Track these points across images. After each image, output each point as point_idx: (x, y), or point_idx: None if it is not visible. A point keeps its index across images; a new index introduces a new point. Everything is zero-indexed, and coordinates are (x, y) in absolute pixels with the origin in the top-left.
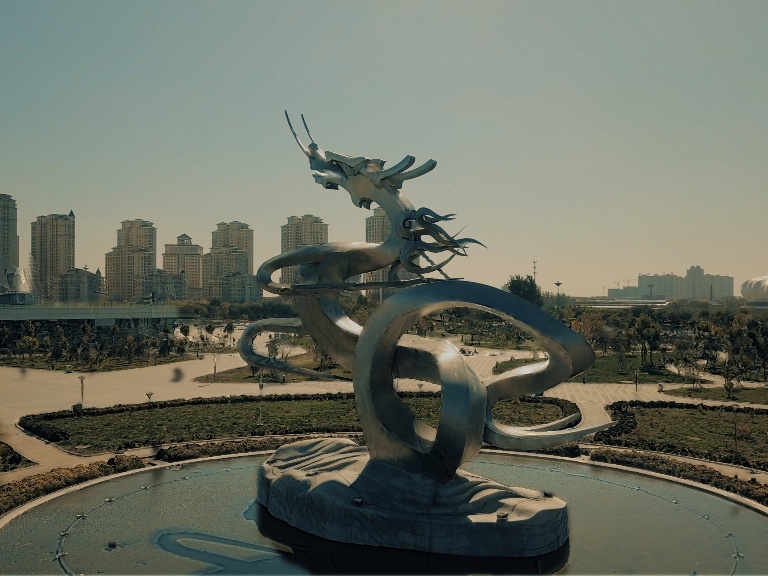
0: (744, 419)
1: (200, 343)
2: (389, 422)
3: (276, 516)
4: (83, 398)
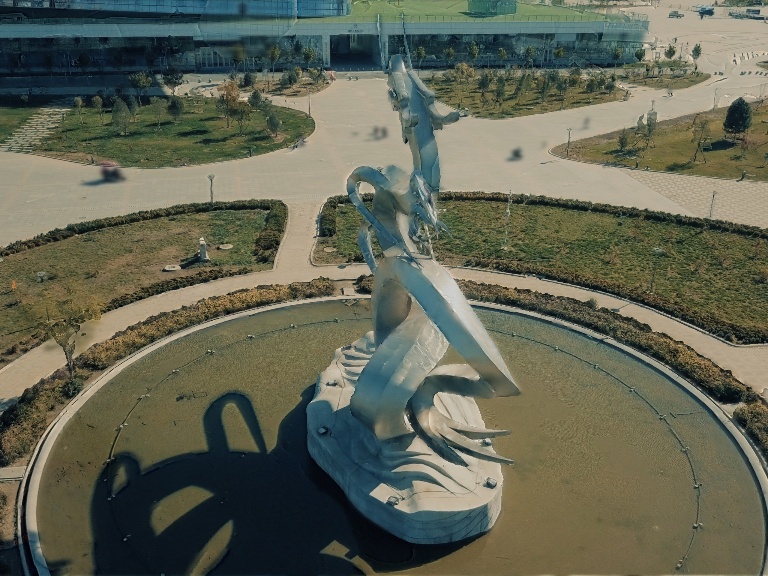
0: None
1: (656, 69)
2: None
3: None
4: None
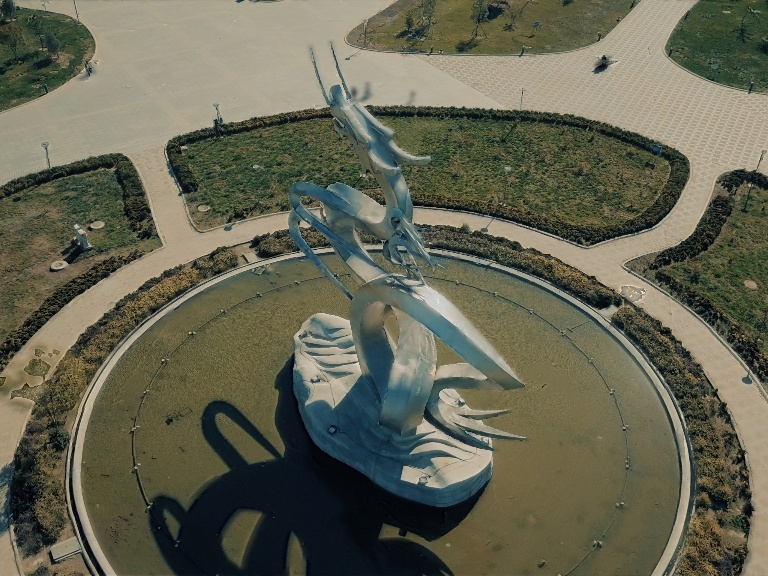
0: None
1: None
2: (372, 363)
3: None
4: (234, 83)
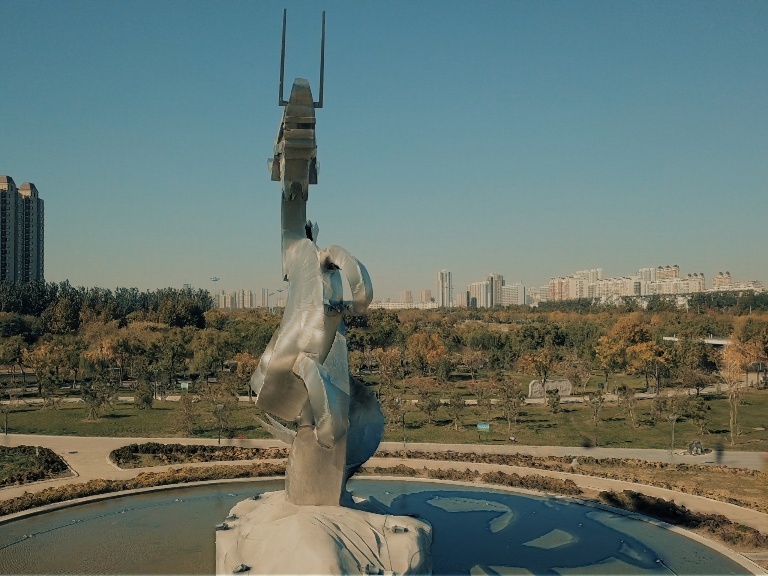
0: None
1: None
2: None
3: None
4: None
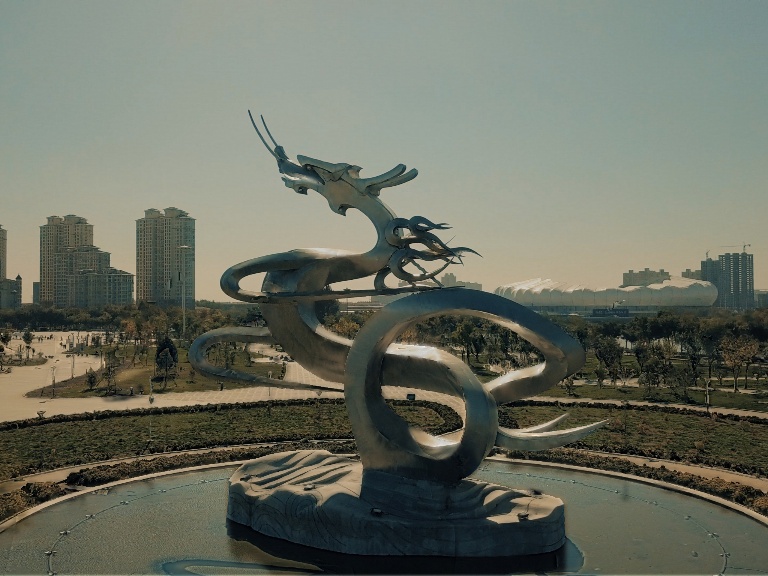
0: (602, 413)
1: None
2: (386, 430)
3: (269, 534)
4: None
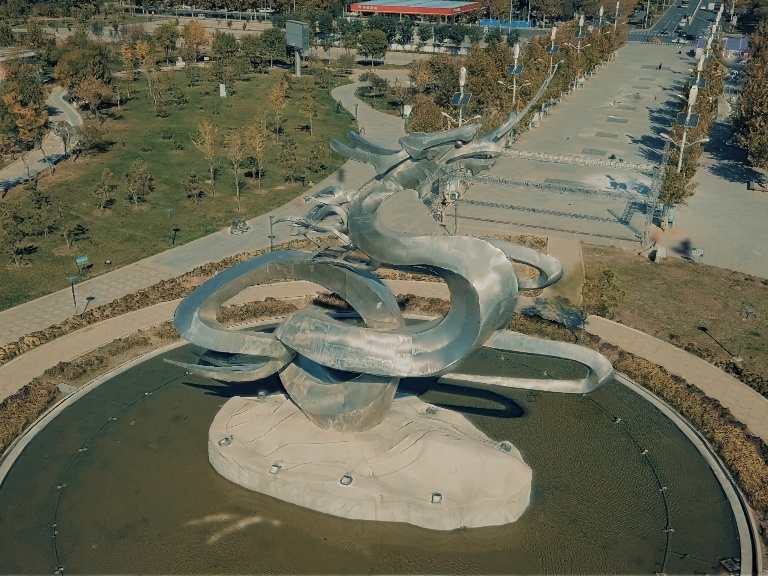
0: None
1: None
2: None
3: None
4: None
